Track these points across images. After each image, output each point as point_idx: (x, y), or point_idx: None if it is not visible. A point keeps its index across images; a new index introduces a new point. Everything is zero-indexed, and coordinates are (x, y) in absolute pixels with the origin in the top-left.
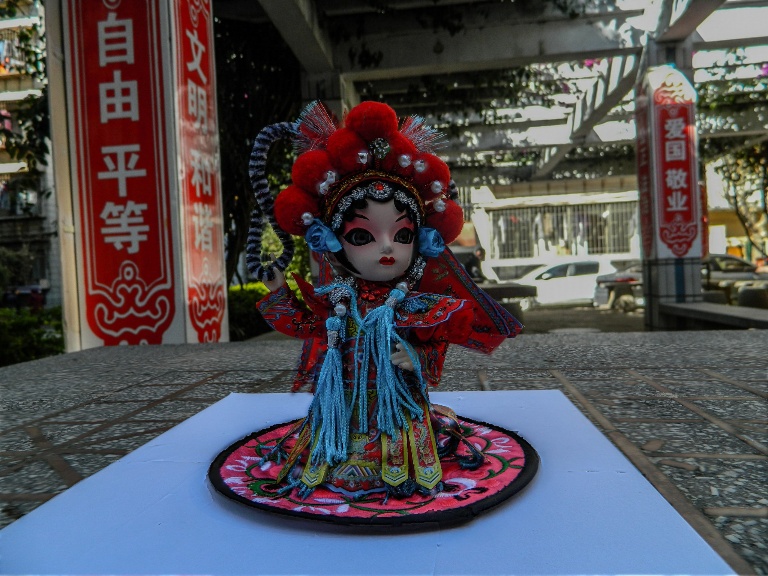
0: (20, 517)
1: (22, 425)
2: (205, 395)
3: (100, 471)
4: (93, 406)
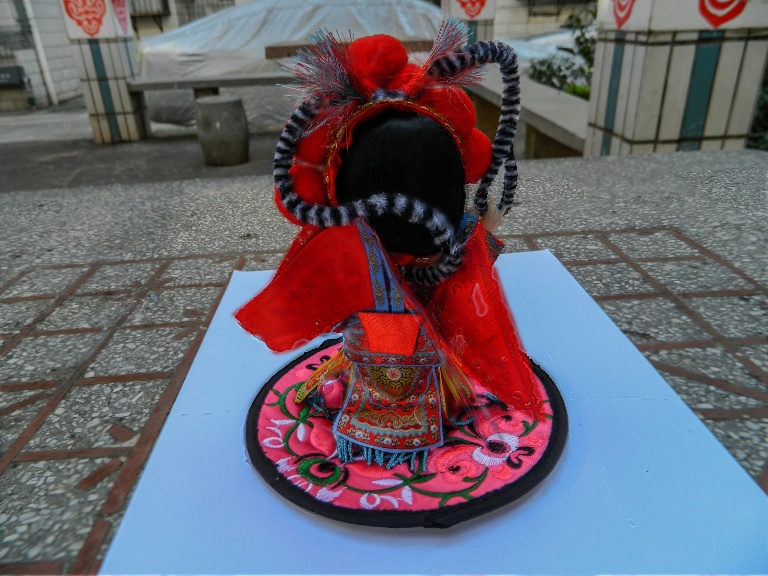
0: None
1: None
2: None
3: (663, 379)
4: None
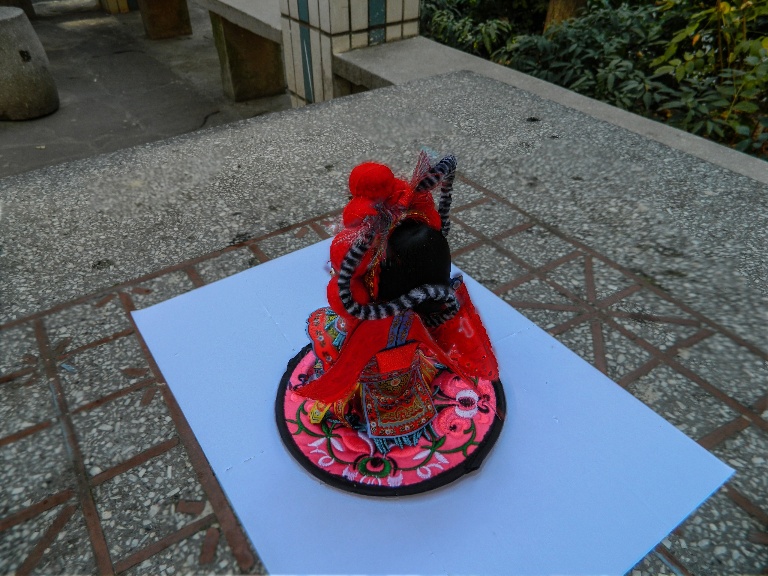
0: (477, 281)
1: (712, 322)
2: (748, 450)
3: (520, 314)
4: (767, 371)
